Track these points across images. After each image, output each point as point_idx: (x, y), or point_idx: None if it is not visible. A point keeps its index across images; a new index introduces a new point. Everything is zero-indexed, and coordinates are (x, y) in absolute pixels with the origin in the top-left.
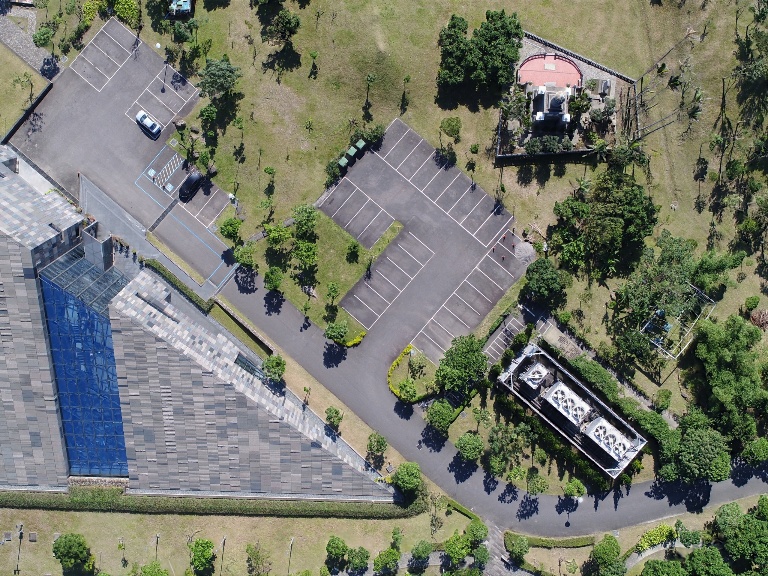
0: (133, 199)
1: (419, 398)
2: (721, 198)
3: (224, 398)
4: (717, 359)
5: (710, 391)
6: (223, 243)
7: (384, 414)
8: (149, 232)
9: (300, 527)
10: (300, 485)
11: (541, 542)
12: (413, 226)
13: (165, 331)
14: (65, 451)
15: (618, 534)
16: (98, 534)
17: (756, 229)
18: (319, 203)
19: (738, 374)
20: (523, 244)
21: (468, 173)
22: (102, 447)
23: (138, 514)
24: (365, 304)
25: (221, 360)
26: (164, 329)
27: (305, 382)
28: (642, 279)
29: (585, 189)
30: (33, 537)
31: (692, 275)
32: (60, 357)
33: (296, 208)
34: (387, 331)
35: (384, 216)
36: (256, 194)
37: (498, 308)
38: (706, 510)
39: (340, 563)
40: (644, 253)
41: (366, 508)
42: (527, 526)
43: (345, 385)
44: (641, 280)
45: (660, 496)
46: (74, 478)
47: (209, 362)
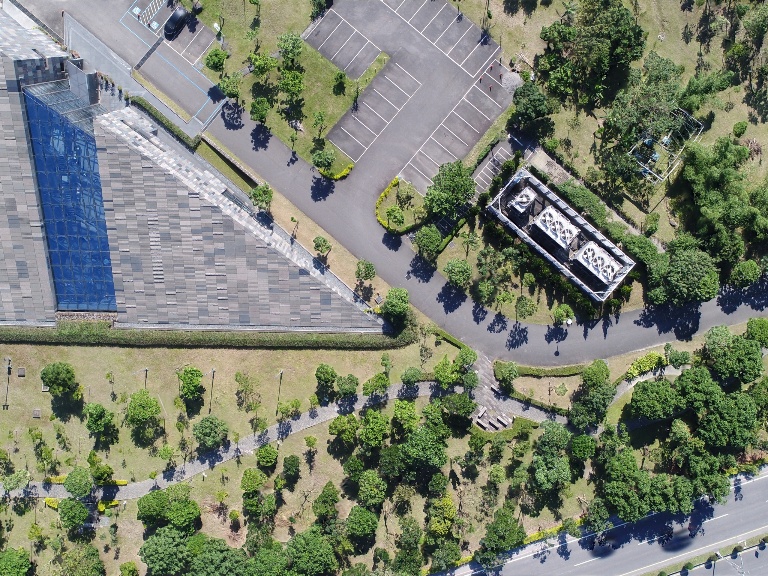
0: (118, 37)
1: (407, 228)
2: (708, 27)
3: (211, 222)
4: (705, 179)
5: (698, 215)
6: (209, 80)
7: (372, 246)
8: (135, 70)
9: (289, 359)
10: (289, 317)
11: (531, 371)
12: (400, 57)
13: (151, 153)
14: (52, 284)
15: (608, 363)
16: (87, 368)
17: (743, 53)
18: (305, 35)
19: (726, 194)
20: (510, 74)
21: (454, 3)
22: (90, 285)
23: (127, 348)
24: (352, 136)
25: (208, 188)
26: (150, 151)
27: (293, 216)
28: (629, 98)
29: (572, 11)
30: (21, 372)
31: (680, 99)
32: (46, 185)
33: (282, 36)
34: (375, 163)
35: (370, 48)
36: (242, 29)
37: (486, 138)
38: (695, 338)
39: (330, 394)
40: (631, 74)
41: (355, 338)
42: (516, 356)
43: (333, 218)
44: (628, 99)
45: (649, 324)
46: (62, 312)
47: (195, 186)
